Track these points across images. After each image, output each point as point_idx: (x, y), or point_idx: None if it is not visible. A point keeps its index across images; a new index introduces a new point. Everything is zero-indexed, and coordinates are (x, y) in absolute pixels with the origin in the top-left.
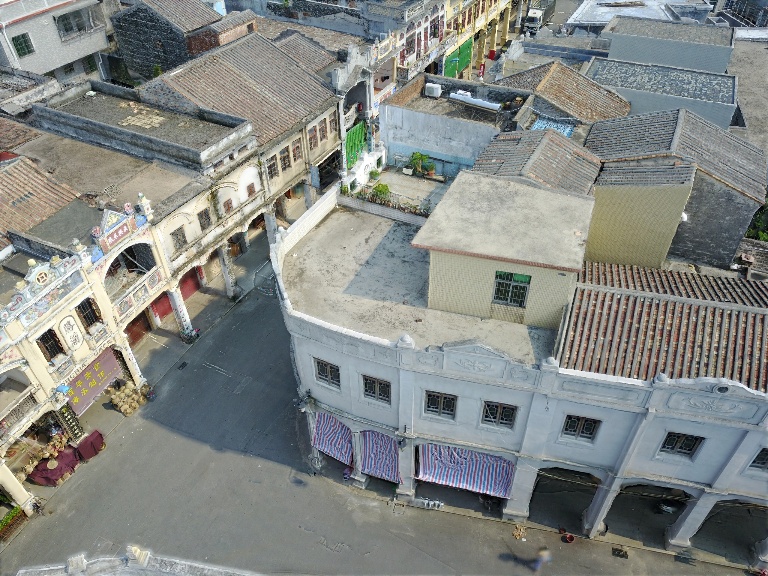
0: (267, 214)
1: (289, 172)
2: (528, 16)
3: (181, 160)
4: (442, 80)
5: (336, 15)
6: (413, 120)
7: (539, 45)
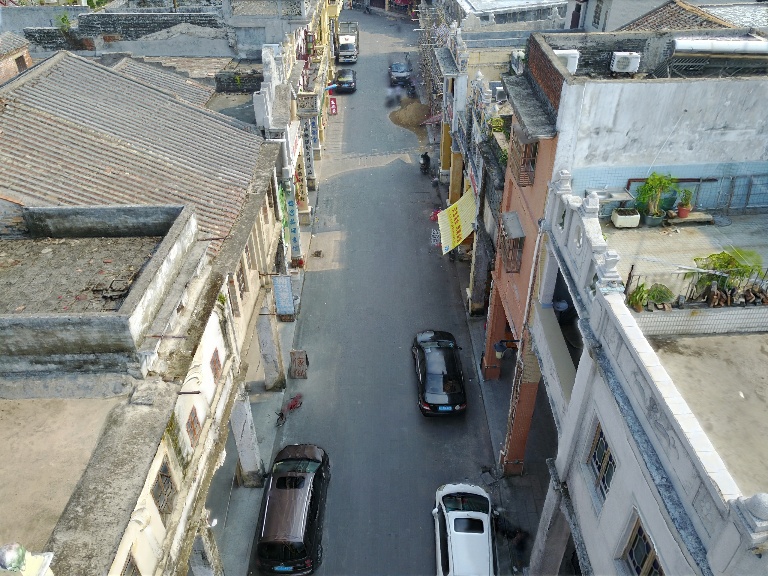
0: (236, 402)
1: (247, 301)
2: (340, 44)
3: (53, 357)
4: (575, 40)
5: (171, 30)
6: (644, 105)
7: (479, 34)
